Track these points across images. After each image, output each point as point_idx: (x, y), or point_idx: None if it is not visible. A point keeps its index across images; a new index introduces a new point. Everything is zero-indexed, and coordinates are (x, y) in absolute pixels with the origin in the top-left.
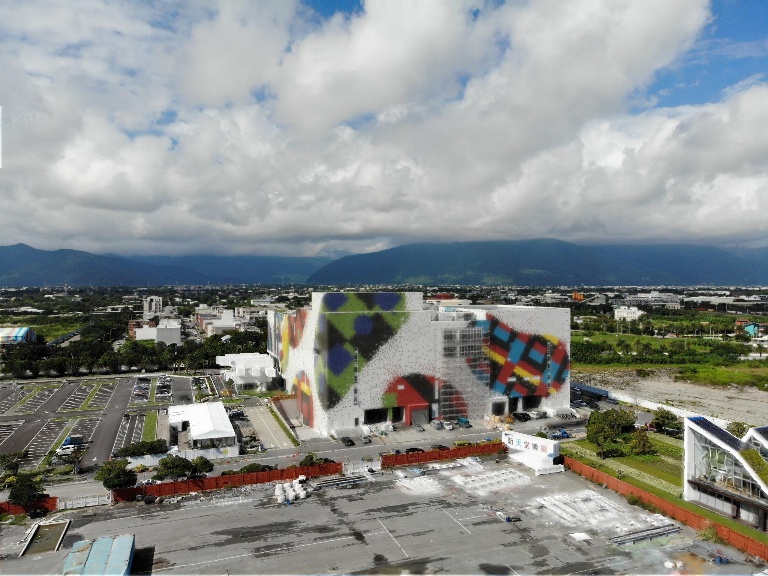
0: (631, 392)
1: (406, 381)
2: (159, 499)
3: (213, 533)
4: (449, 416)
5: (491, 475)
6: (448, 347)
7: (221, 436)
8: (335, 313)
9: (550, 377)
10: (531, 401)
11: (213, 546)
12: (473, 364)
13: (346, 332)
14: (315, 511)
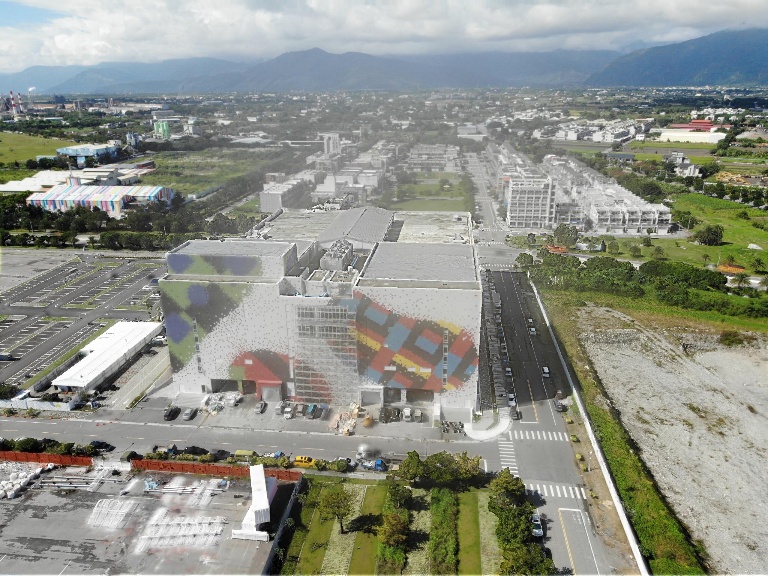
0: (662, 375)
1: (254, 356)
2: None
3: None
4: (306, 398)
5: (184, 523)
6: (302, 326)
7: (74, 385)
8: (166, 281)
9: (447, 371)
10: (430, 391)
11: None
12: (334, 347)
13: (181, 301)
14: None
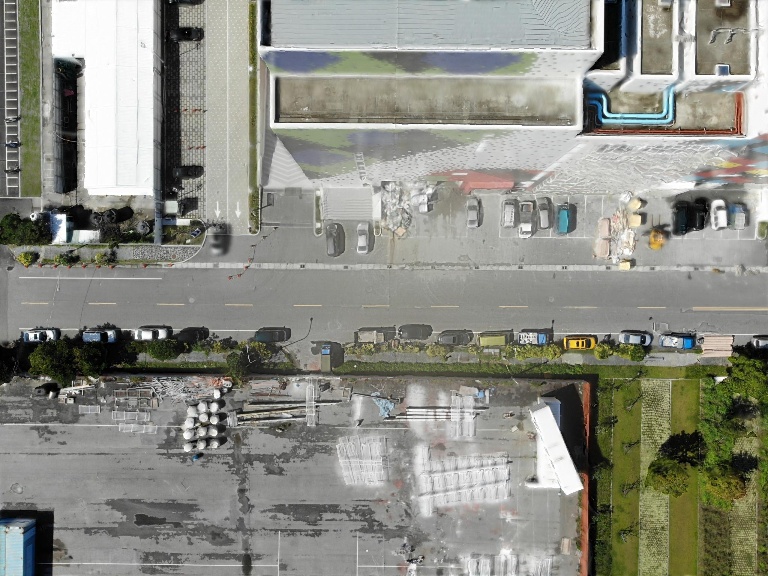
0: None
1: (473, 171)
2: (52, 395)
3: (108, 503)
4: None
5: (462, 473)
6: (598, 157)
7: (130, 194)
8: (292, 128)
9: None
10: None
11: (106, 534)
12: None
13: (329, 142)
14: (220, 488)
